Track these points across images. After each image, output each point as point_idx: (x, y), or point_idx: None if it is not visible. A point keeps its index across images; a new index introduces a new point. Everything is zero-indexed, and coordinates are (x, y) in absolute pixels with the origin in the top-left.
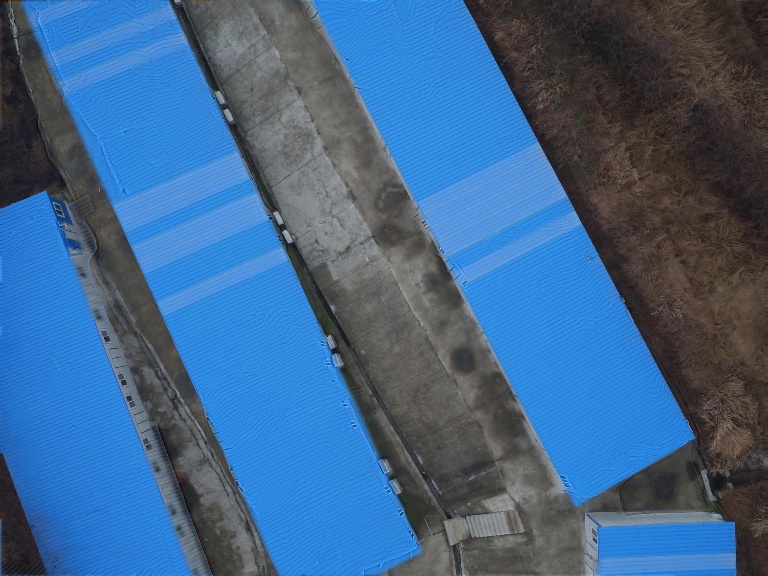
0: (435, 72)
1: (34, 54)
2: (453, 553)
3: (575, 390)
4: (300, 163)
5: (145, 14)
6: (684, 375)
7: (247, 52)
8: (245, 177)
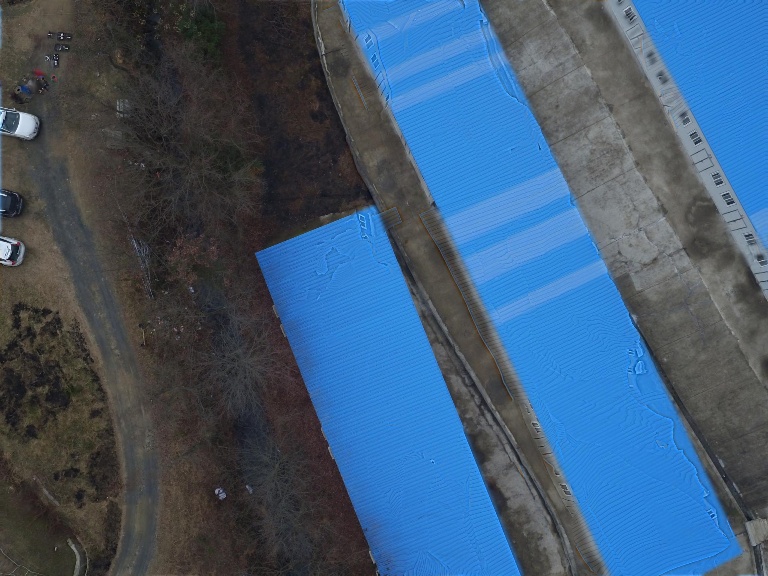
0: None
1: (342, 71)
2: (754, 553)
3: None
4: (607, 178)
5: (460, 33)
6: None
7: (554, 70)
8: (566, 191)
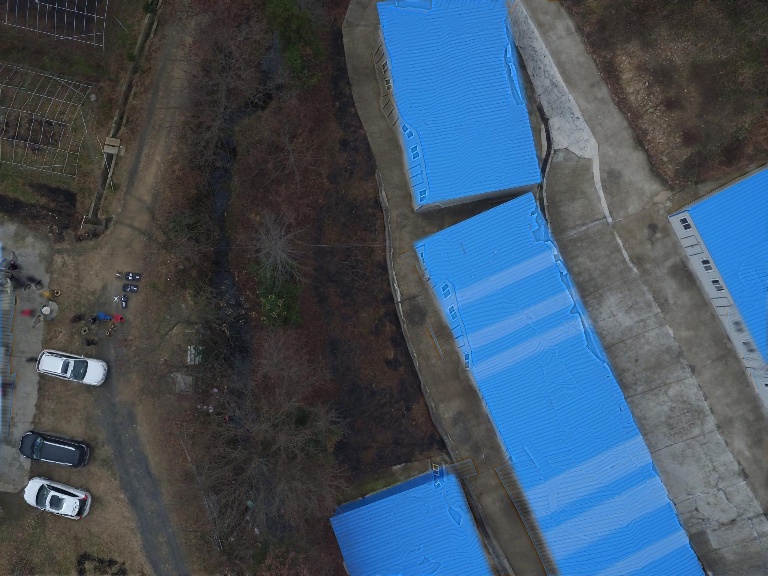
0: None
1: (418, 318)
2: None
3: None
4: (686, 436)
5: None
6: None
7: (635, 326)
8: (648, 459)
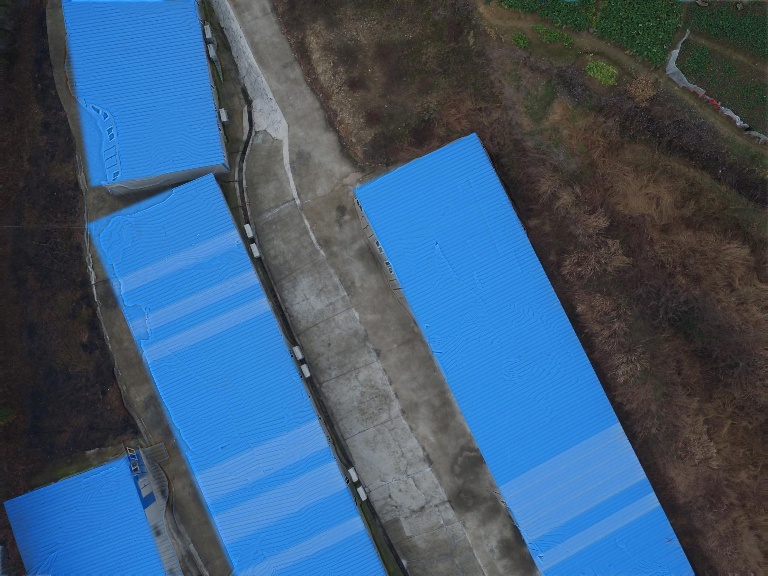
0: (529, 391)
1: (112, 301)
2: None
3: None
4: (376, 421)
5: (226, 272)
6: None
7: (325, 309)
8: (324, 444)
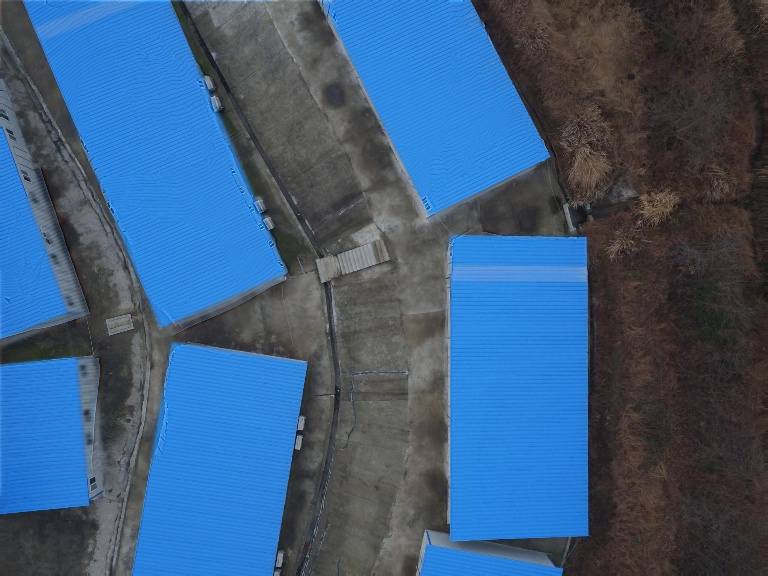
0: None
1: None
2: (325, 292)
3: (443, 127)
4: None
5: None
6: (545, 106)
7: None
8: None
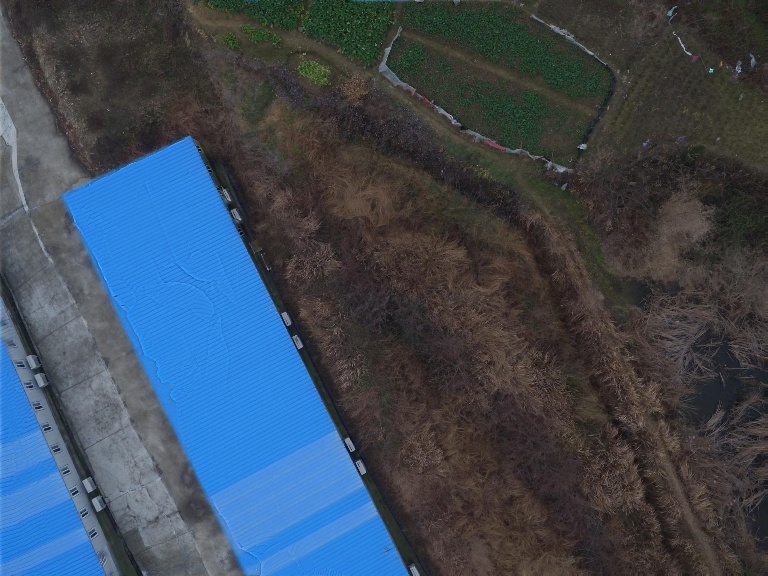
0: (204, 400)
1: None
2: None
3: None
4: (110, 430)
5: None
6: None
7: (58, 317)
8: (47, 455)
